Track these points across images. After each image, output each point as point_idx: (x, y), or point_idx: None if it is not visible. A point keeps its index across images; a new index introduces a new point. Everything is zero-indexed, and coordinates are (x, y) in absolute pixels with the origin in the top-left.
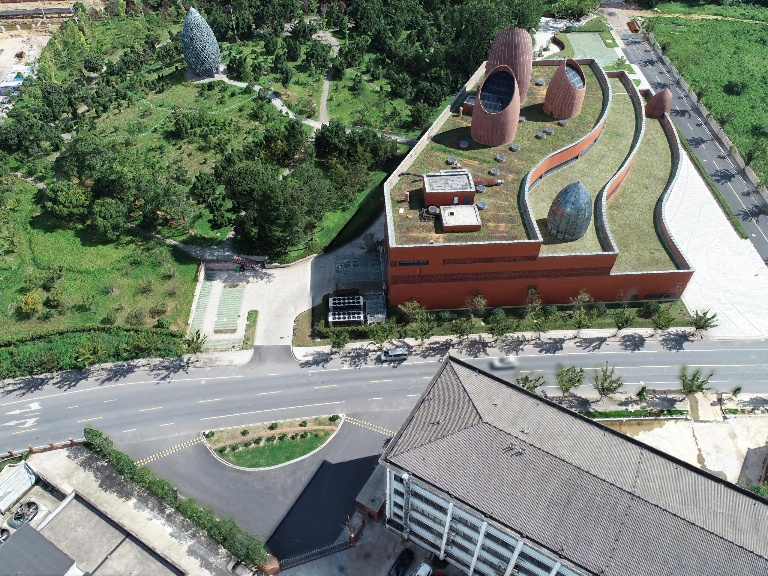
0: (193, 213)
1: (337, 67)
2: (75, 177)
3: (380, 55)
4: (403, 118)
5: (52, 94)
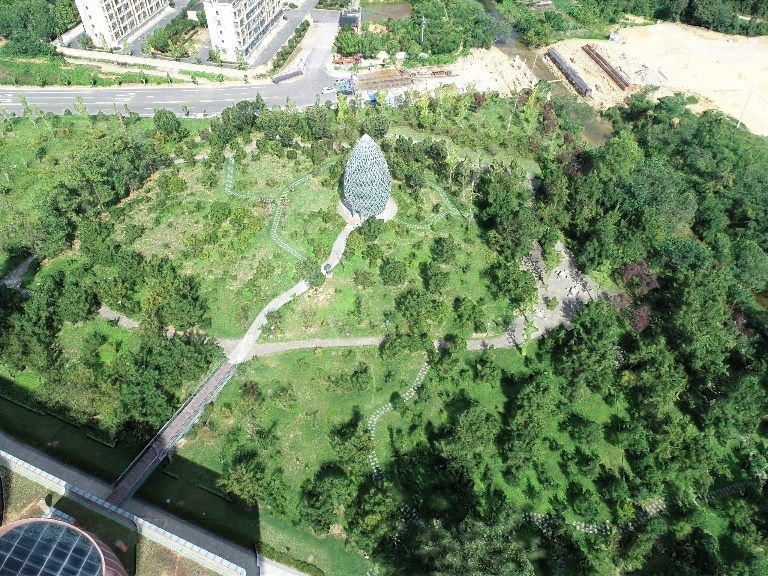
0: (17, 246)
1: (390, 341)
2: (167, 169)
3: (505, 414)
4: (271, 464)
5: (295, 115)
